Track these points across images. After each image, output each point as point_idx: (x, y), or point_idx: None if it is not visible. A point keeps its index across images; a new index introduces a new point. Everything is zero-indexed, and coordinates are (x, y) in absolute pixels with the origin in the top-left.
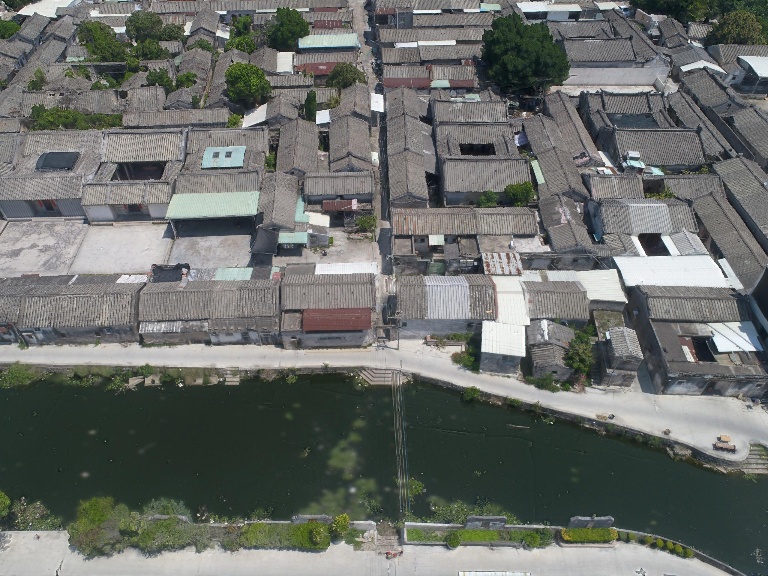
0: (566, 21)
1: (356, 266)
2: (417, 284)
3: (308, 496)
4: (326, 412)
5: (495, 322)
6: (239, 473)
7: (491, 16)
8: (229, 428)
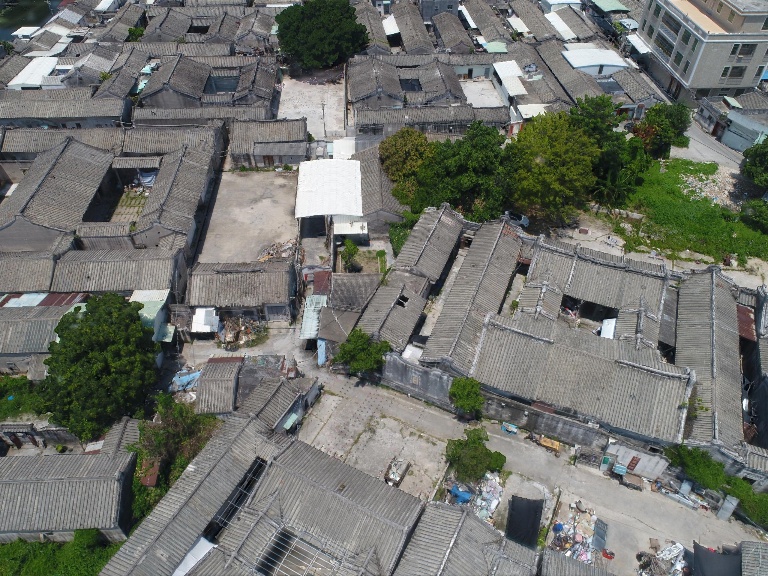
0: (439, 69)
1: (105, 6)
2: (67, 7)
3: (2, 20)
4: (41, 24)
5: (37, 29)
6: (23, 11)
7: (457, 43)
8: (46, 8)
